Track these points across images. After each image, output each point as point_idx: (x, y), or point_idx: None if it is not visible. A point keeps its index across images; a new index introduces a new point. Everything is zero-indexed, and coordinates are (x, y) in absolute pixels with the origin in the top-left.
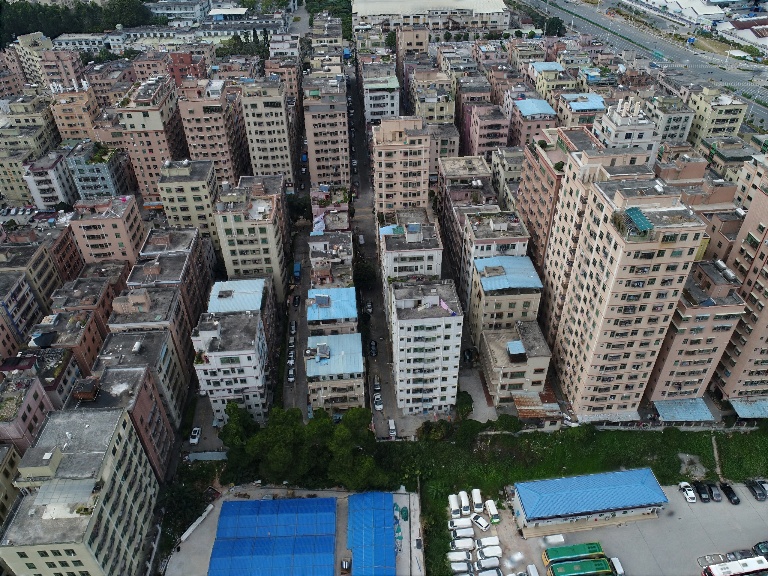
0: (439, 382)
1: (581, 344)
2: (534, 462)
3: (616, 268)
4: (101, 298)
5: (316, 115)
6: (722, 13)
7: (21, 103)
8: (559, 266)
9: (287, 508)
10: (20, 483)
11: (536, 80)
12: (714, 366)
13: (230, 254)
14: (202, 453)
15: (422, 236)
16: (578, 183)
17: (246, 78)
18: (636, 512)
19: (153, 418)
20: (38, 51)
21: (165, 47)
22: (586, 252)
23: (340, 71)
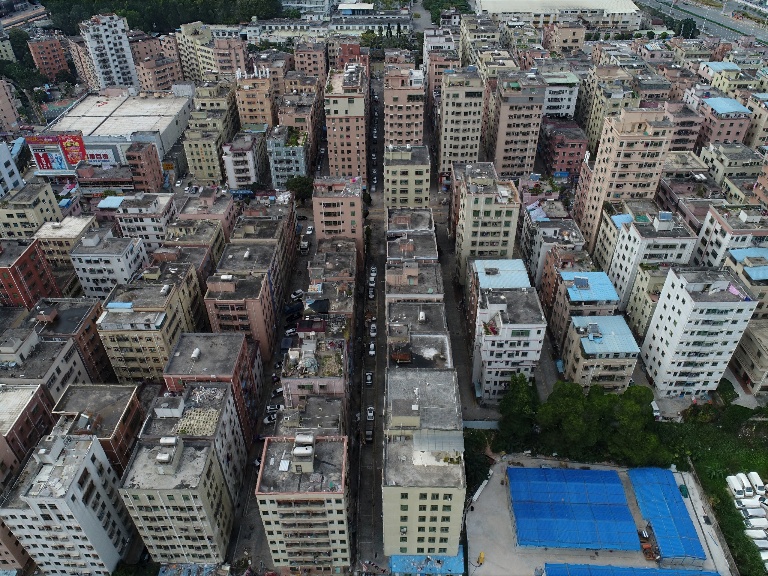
0: (708, 366)
1: None
2: None
3: None
4: None
5: (513, 106)
6: None
7: (207, 88)
8: None
9: (573, 477)
10: (392, 431)
11: (711, 79)
12: None
13: (471, 235)
14: (473, 421)
15: None
16: None
17: None
18: None
19: None
20: (201, 39)
21: (313, 39)
22: None
23: (515, 65)
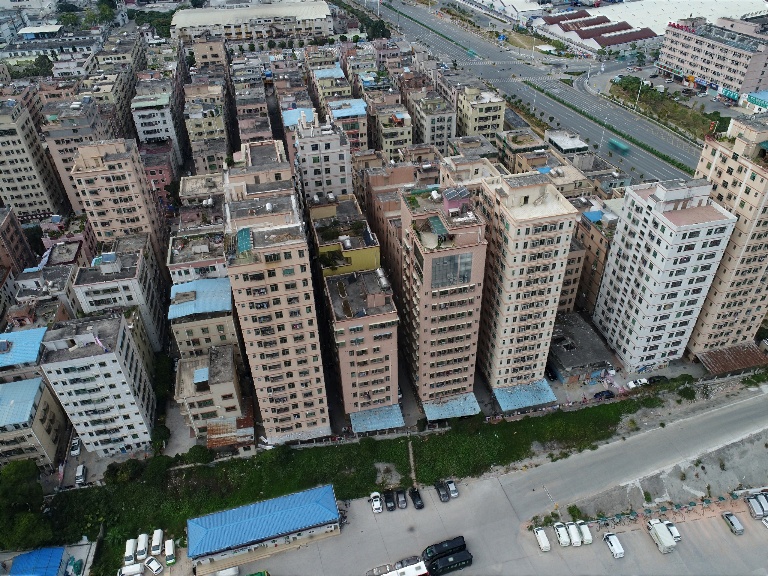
0: (122, 421)
1: None
2: (231, 491)
3: None
4: None
5: (59, 140)
6: (540, 9)
7: None
8: None
9: None
10: None
11: (318, 88)
12: (395, 373)
13: None
14: None
15: (116, 266)
16: None
17: None
18: (317, 531)
19: None
20: None
21: None
22: None
23: (110, 90)
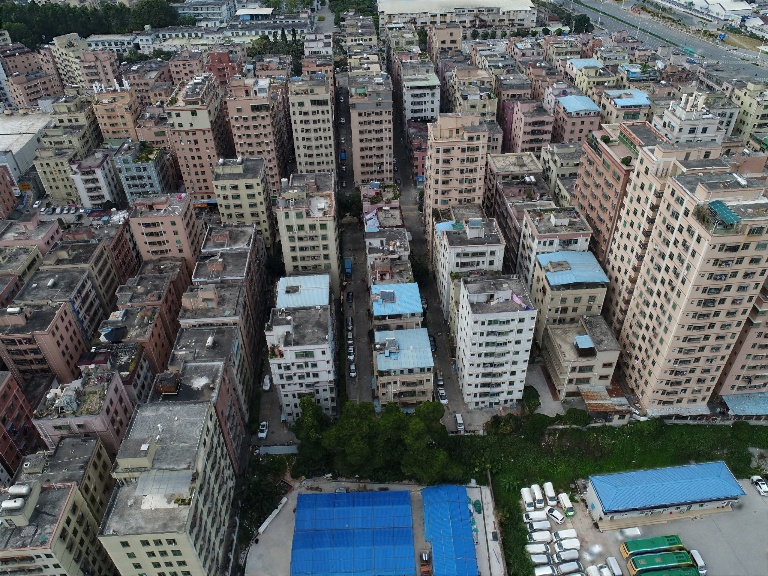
0: (507, 376)
1: (653, 338)
2: (603, 456)
3: (699, 261)
4: (165, 294)
5: (362, 113)
6: (750, 9)
7: (64, 103)
8: (626, 261)
9: (362, 501)
10: (119, 474)
11: (575, 77)
12: None
13: (290, 250)
14: (273, 447)
15: (484, 232)
16: (652, 177)
17: (283, 77)
18: (711, 505)
19: (230, 412)
20: (74, 52)
21: (197, 47)
22: (661, 246)
23: (379, 69)
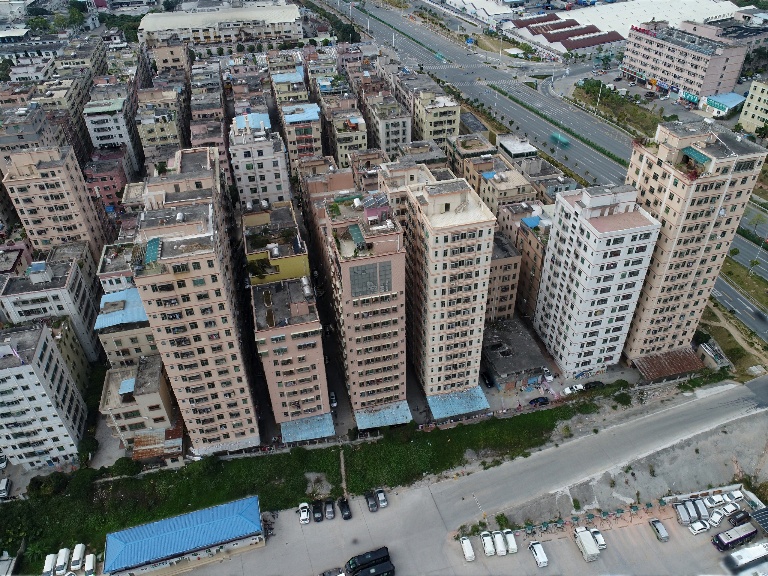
0: (45, 433)
1: None
2: (158, 503)
3: None
4: None
5: (5, 147)
6: (511, 12)
7: None
8: None
9: None
10: None
11: None
12: (323, 382)
13: None
14: None
15: (46, 275)
16: None
17: None
18: (241, 544)
19: None
20: None
21: None
22: None
23: (63, 96)
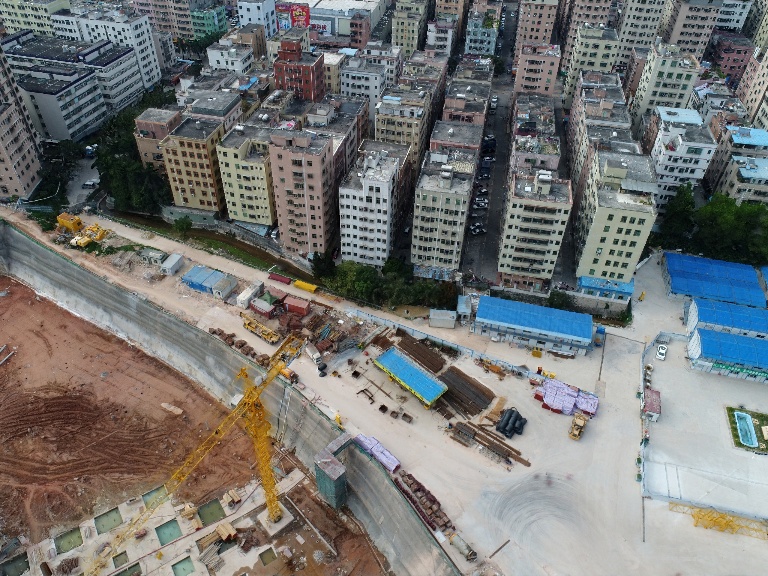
0: None
1: None
2: None
3: None
4: None
5: (693, 8)
6: None
7: None
8: None
9: (717, 263)
10: (605, 178)
11: None
12: None
13: (651, 94)
14: None
15: None
16: None
17: None
18: None
19: None
20: None
21: None
22: None
23: None
